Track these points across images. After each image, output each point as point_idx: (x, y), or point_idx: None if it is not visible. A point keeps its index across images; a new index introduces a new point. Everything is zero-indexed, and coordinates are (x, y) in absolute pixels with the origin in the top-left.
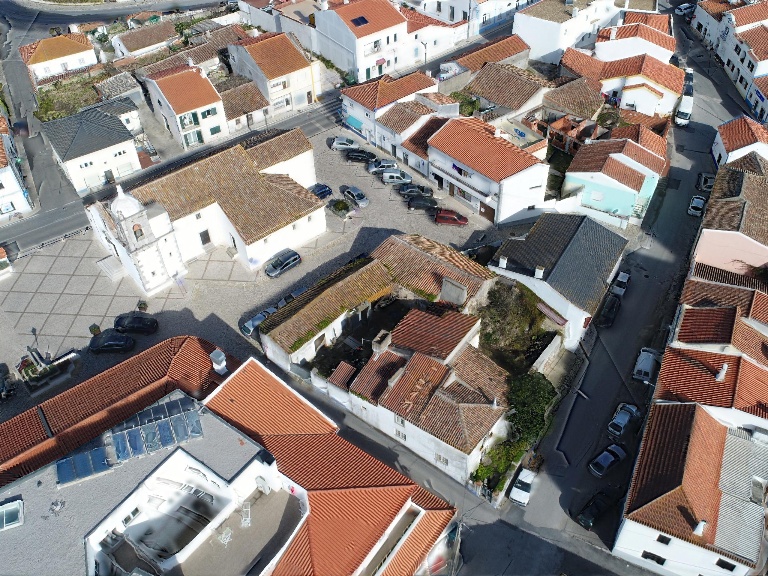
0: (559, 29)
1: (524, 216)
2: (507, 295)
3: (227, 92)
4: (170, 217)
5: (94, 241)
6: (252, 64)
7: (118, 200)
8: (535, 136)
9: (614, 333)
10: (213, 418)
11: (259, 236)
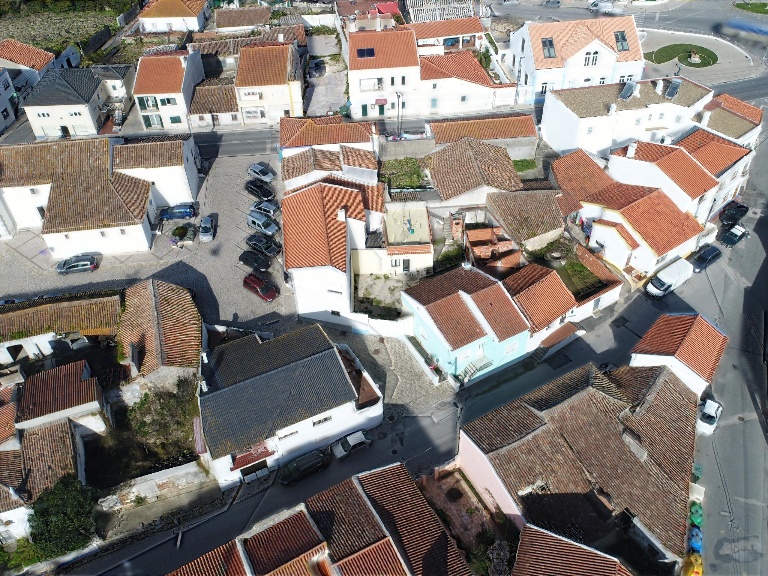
0: (578, 124)
1: (329, 319)
2: (191, 392)
3: (212, 87)
4: (3, 183)
5: None
6: None
7: None
8: (429, 237)
9: (285, 494)
10: None
11: (58, 229)
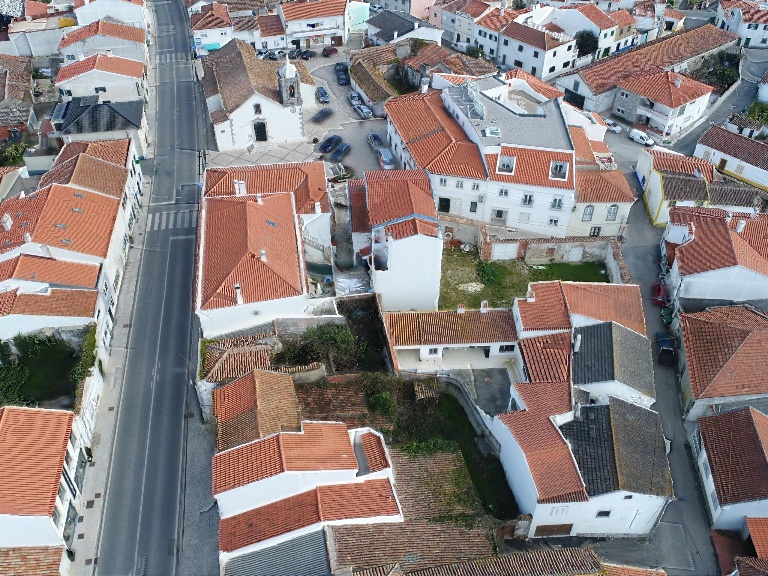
0: None
1: None
2: None
3: None
4: None
5: (224, 152)
6: (115, 43)
7: (290, 66)
8: None
9: None
10: None
11: None
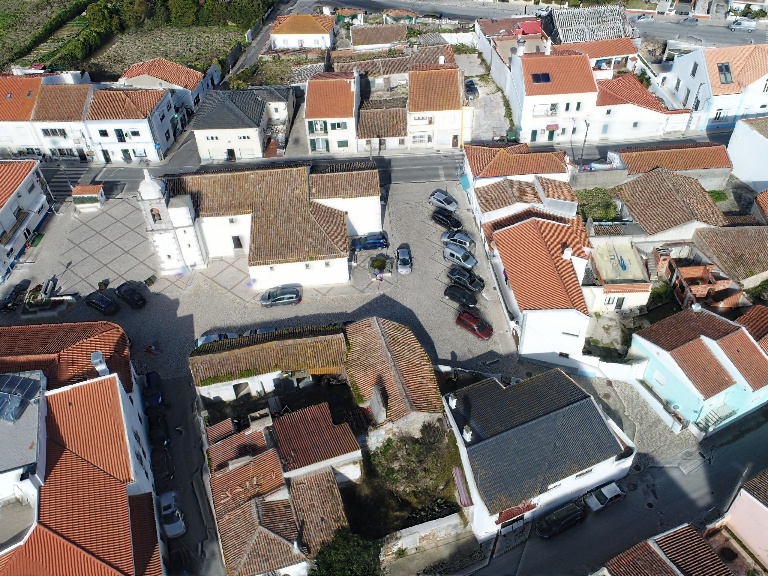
0: None
1: (554, 360)
2: (439, 439)
3: (377, 110)
4: (203, 212)
5: None
6: None
7: (144, 181)
8: (643, 274)
9: (546, 549)
10: (36, 411)
11: (265, 261)
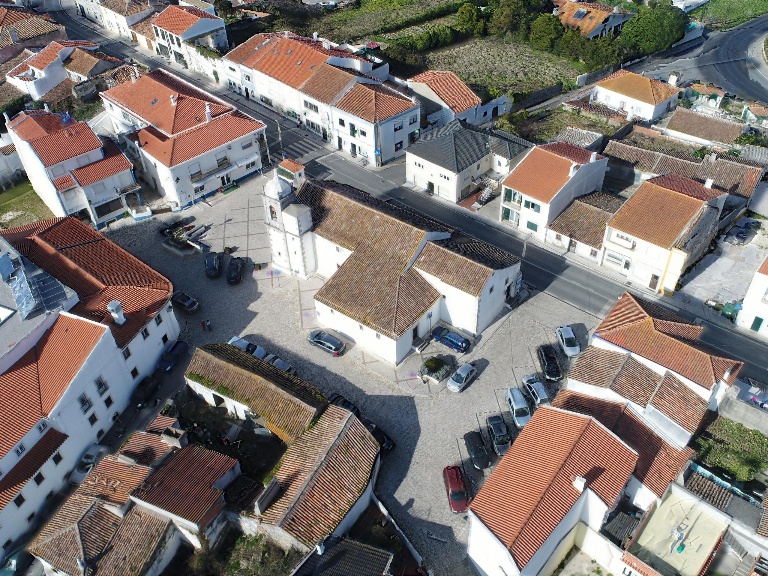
0: None
1: None
2: None
3: (592, 207)
4: (320, 229)
5: None
6: None
7: None
8: None
9: None
10: (41, 321)
11: (328, 301)
